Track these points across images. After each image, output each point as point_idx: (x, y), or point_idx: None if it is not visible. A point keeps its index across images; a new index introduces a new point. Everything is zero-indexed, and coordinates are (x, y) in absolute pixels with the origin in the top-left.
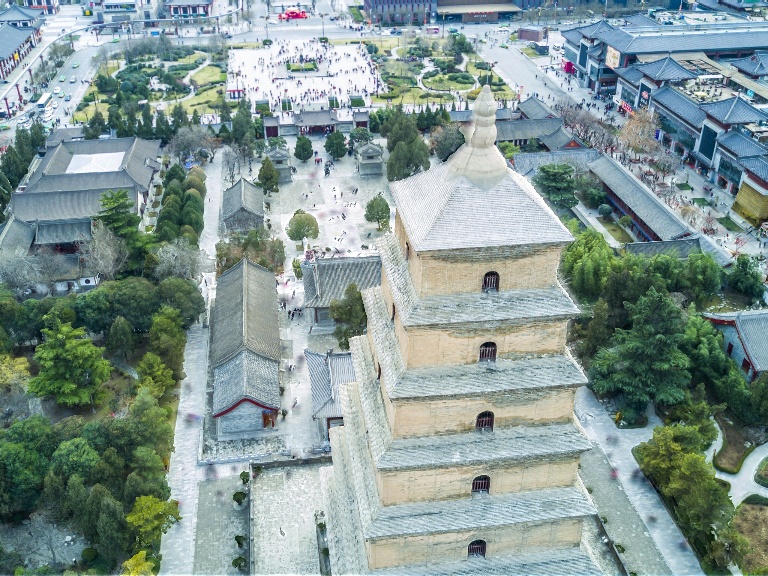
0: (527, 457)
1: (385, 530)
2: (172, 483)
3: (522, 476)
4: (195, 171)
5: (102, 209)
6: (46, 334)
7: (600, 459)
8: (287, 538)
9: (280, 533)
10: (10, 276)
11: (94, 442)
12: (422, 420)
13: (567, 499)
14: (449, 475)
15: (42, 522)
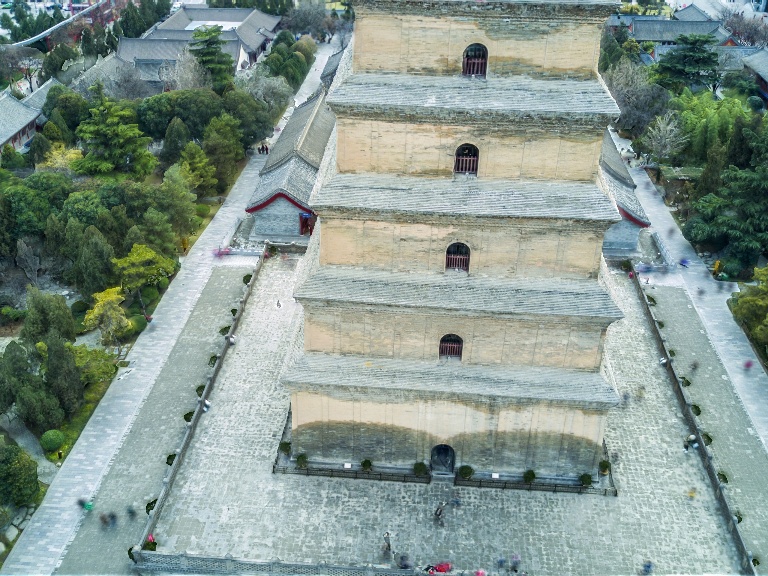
0: (528, 120)
1: (335, 199)
2: (187, 264)
3: (522, 154)
4: (305, 40)
5: (193, 41)
6: (93, 113)
7: (684, 303)
8: (282, 309)
9: (276, 304)
10: (87, 84)
11: (107, 200)
12: (390, 45)
13: (582, 197)
14: (423, 136)
15: (27, 251)
